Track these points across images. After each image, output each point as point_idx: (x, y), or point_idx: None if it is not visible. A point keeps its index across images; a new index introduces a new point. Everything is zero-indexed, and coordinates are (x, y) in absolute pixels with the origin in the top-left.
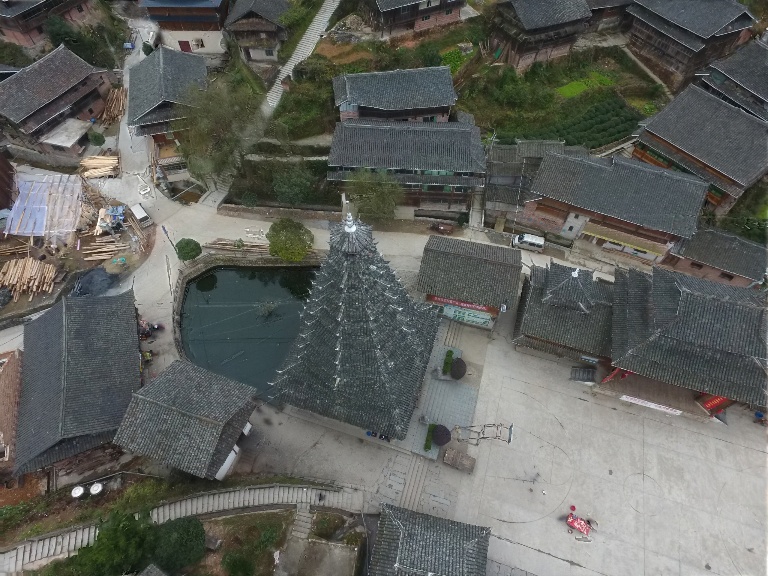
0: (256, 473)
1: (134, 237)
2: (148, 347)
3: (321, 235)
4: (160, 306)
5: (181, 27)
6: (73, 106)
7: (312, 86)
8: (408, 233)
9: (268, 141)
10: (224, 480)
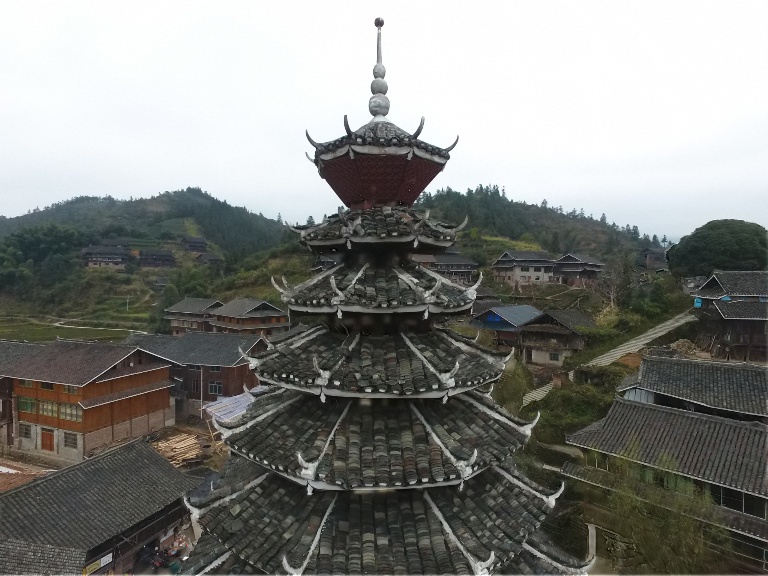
0: None
1: None
2: None
3: None
4: None
5: None
6: None
7: (596, 389)
8: None
9: None
10: None
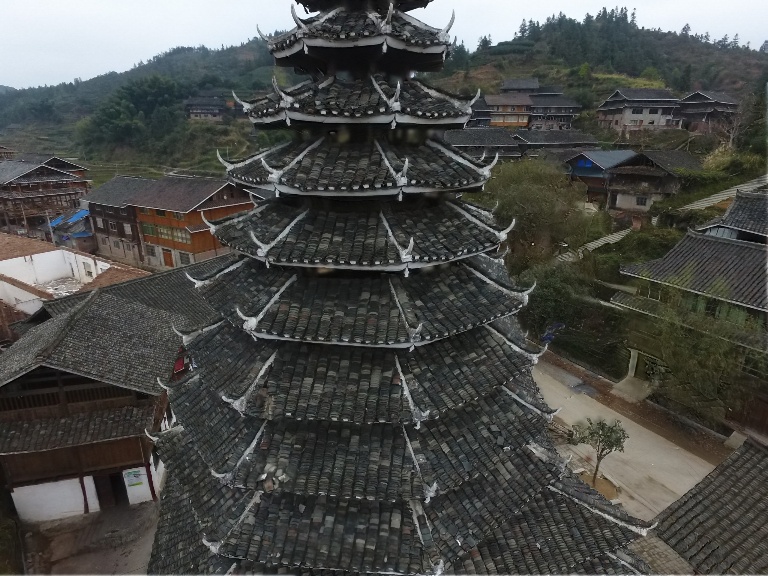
0: (49, 572)
1: None
2: None
3: (552, 387)
4: None
5: None
6: None
7: None
8: None
9: None
10: (26, 526)
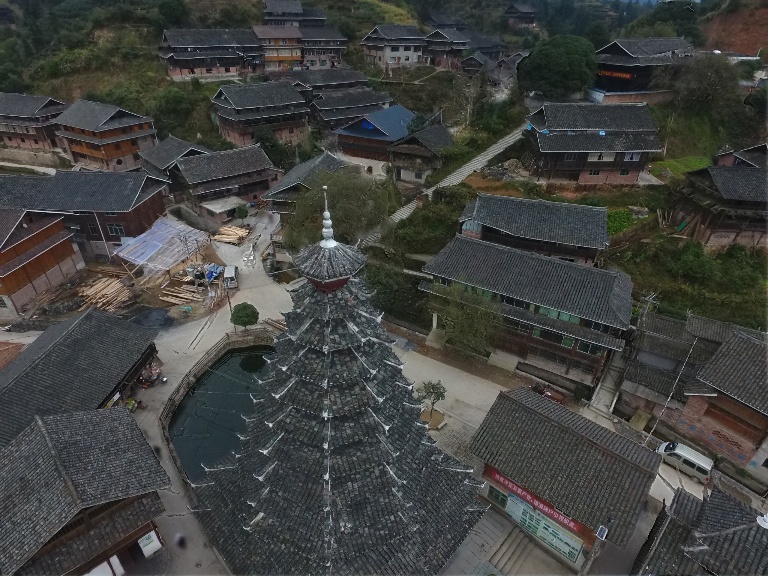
0: None
1: (211, 292)
2: (142, 397)
3: None
4: (186, 362)
5: (359, 154)
6: (242, 188)
7: (447, 208)
8: (499, 385)
9: (382, 247)
10: None
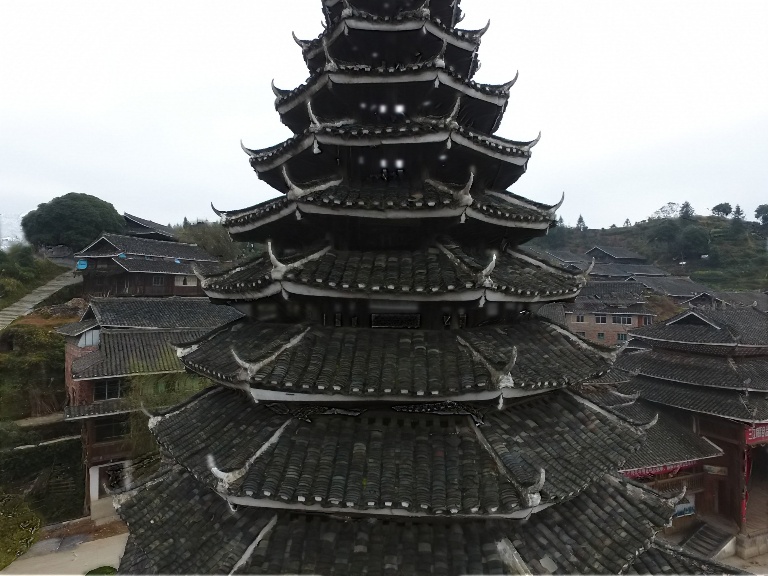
0: None
1: None
2: None
3: (39, 565)
4: None
5: None
6: None
7: None
8: None
9: None
10: None
